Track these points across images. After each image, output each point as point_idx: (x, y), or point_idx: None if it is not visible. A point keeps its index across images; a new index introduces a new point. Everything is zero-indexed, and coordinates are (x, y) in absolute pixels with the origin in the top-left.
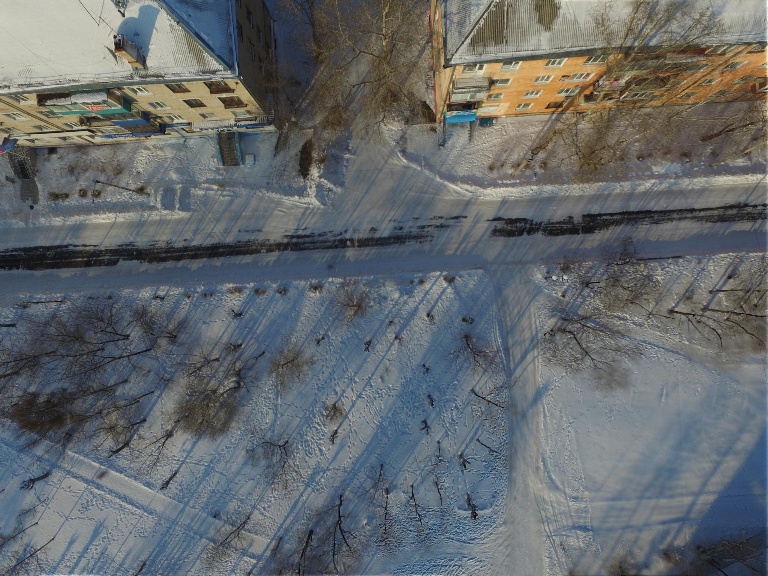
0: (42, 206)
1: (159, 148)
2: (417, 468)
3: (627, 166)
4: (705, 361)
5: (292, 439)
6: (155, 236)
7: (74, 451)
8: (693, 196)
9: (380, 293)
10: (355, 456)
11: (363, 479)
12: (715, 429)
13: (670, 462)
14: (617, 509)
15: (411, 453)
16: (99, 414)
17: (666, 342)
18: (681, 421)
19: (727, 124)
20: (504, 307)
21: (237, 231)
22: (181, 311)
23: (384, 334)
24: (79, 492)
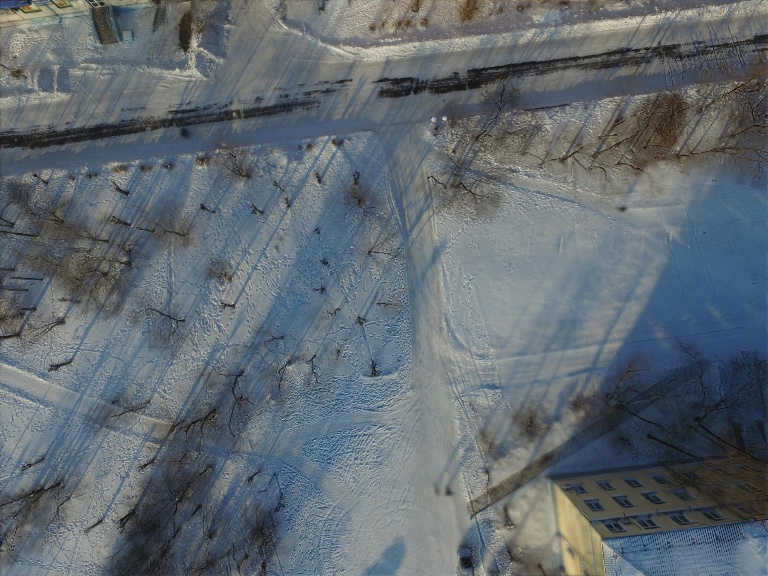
0: None
1: (34, 30)
2: (319, 337)
3: (508, 18)
4: (600, 207)
5: (189, 317)
6: (36, 121)
7: None
8: (576, 44)
9: (269, 161)
10: (255, 330)
11: (264, 353)
12: (615, 275)
13: (573, 312)
14: (524, 364)
15: (311, 322)
16: None
17: (560, 191)
18: (580, 269)
19: None
20: (396, 168)
21: (120, 110)
22: (66, 195)
23: (276, 204)
24: None
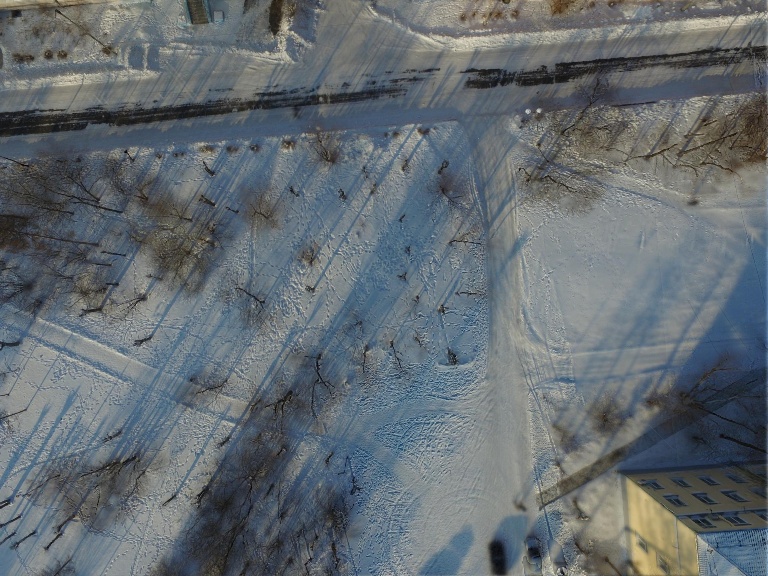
0: (7, 70)
1: (126, 8)
2: (396, 324)
3: (599, 13)
4: (682, 206)
5: (268, 299)
6: (124, 98)
7: (45, 319)
8: (665, 42)
9: (354, 147)
10: (333, 314)
11: (342, 337)
12: (694, 274)
13: (651, 309)
14: (599, 359)
15: (390, 309)
16: (70, 278)
17: (643, 188)
18: (660, 267)
19: None
20: (480, 159)
21: (207, 90)
22: (152, 172)
23: (359, 190)
24: (51, 361)
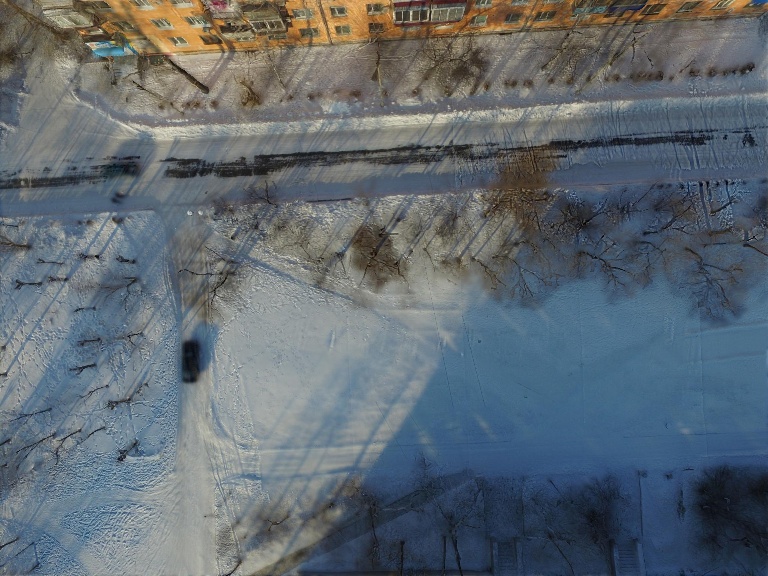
0: None
1: None
2: (85, 412)
3: (298, 106)
4: (375, 306)
5: None
6: None
7: None
8: (365, 137)
9: (50, 233)
10: (25, 399)
11: (32, 423)
12: (384, 376)
13: (339, 409)
14: (287, 457)
15: None
16: None
17: (336, 286)
18: (349, 367)
19: (399, 63)
20: (175, 249)
21: None
22: None
23: (55, 276)
24: None
